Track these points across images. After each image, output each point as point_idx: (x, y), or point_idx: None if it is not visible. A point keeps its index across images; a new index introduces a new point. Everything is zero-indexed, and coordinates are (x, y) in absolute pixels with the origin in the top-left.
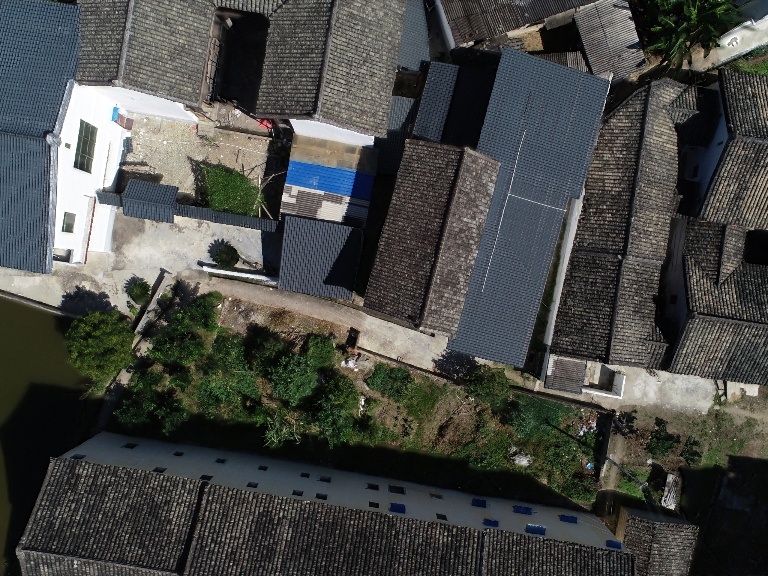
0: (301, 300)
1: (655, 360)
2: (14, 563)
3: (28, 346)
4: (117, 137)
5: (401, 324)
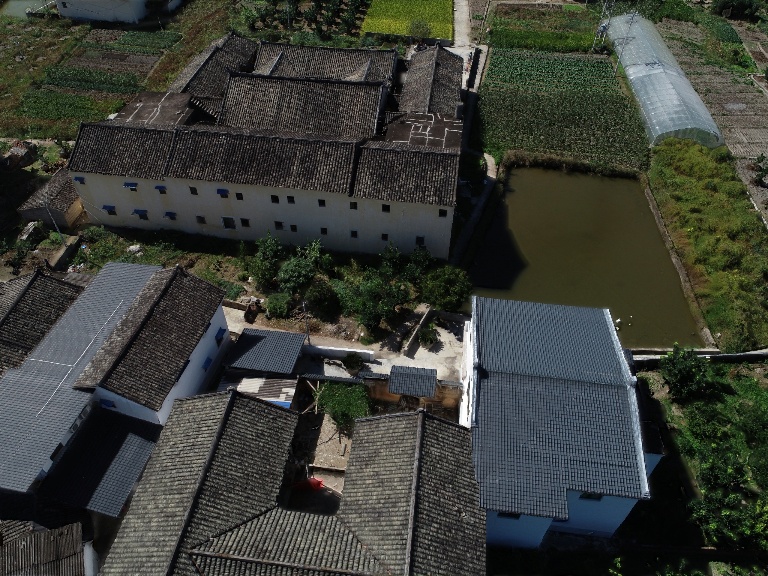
0: None
1: None
2: (498, 199)
3: None
4: None
5: None
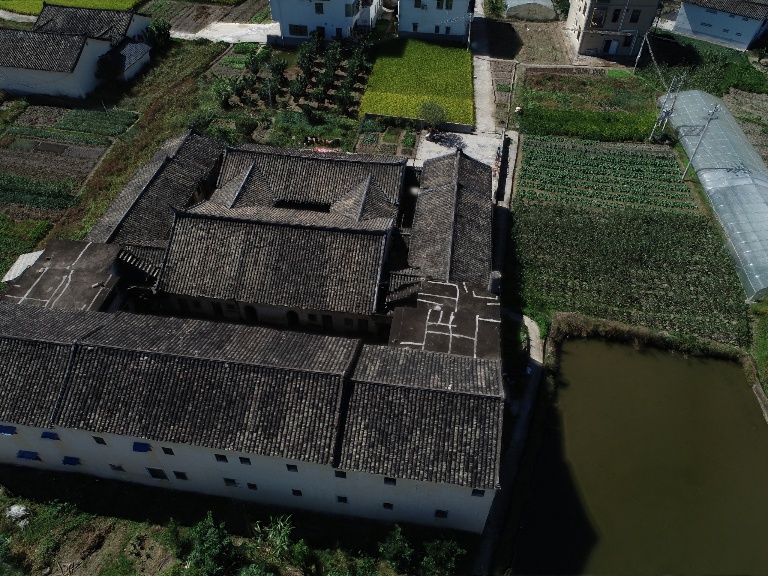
0: None
1: None
2: (549, 405)
3: None
4: None
5: None
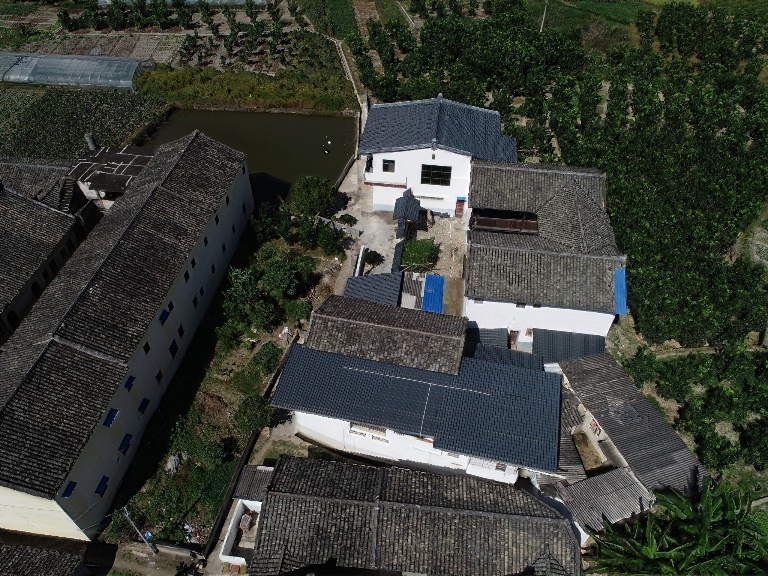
0: None
1: (261, 568)
2: None
3: None
4: (448, 206)
5: None
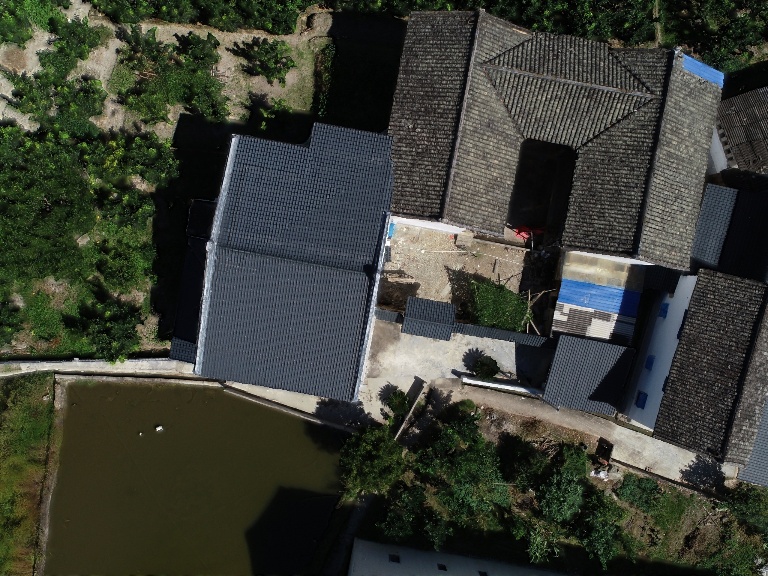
0: (552, 409)
1: None
2: None
3: (271, 447)
4: None
5: (649, 434)
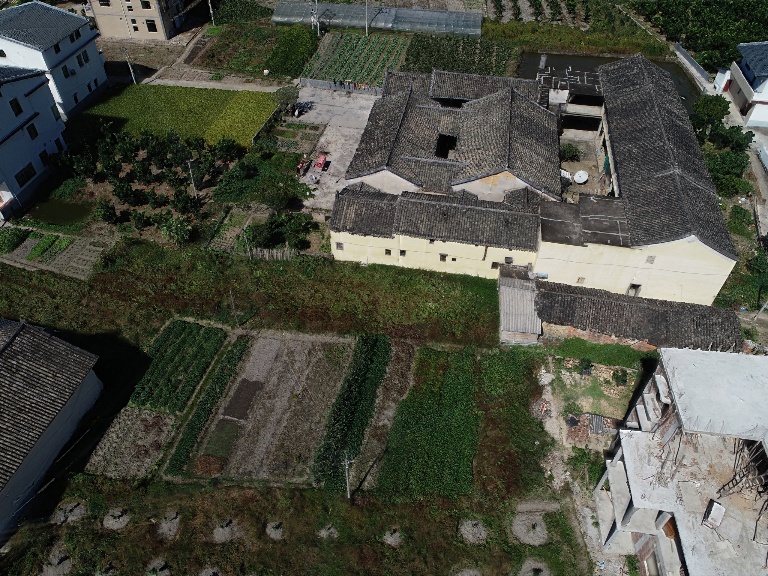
0: (767, 184)
1: None
2: None
3: None
4: None
5: None
